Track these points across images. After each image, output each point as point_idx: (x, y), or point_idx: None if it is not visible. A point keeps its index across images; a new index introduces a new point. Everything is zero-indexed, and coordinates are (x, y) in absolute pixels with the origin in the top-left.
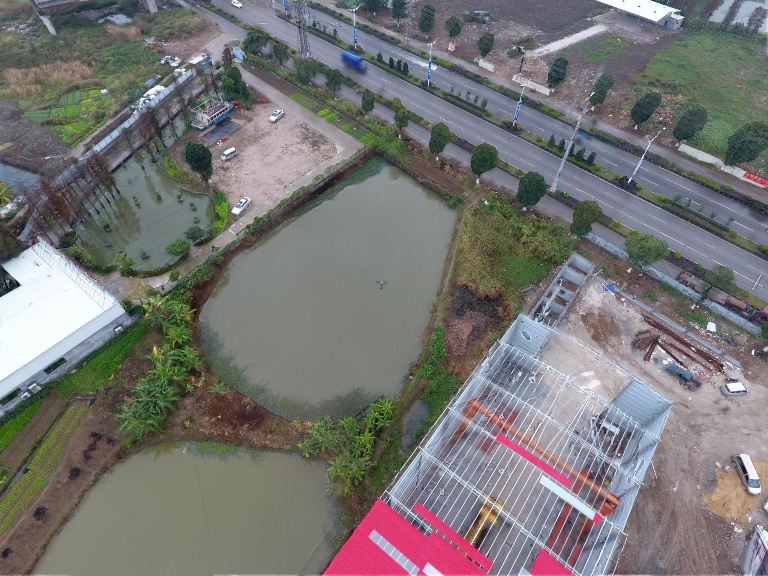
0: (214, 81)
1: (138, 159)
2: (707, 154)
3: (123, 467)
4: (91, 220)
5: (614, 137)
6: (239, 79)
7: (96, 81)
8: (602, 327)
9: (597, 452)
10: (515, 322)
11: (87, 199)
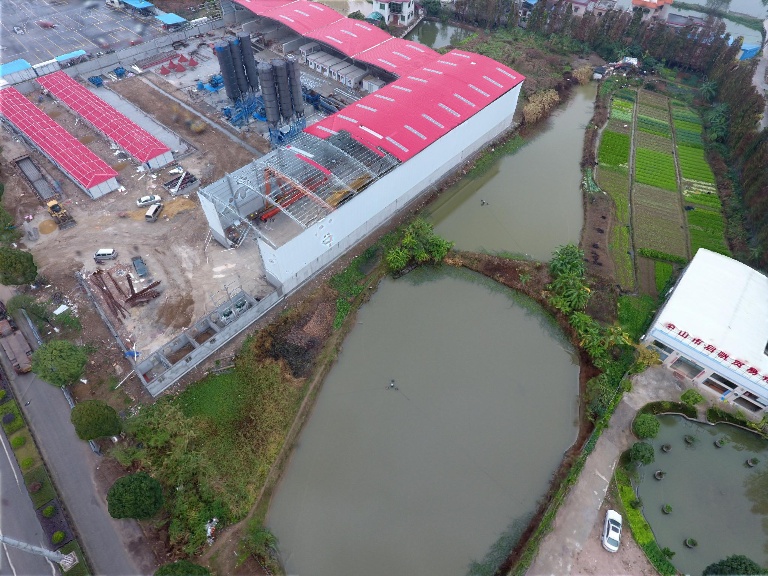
0: None
1: None
2: None
3: None
4: None
5: None
6: None
7: None
8: (176, 311)
9: (272, 165)
10: (283, 248)
11: None
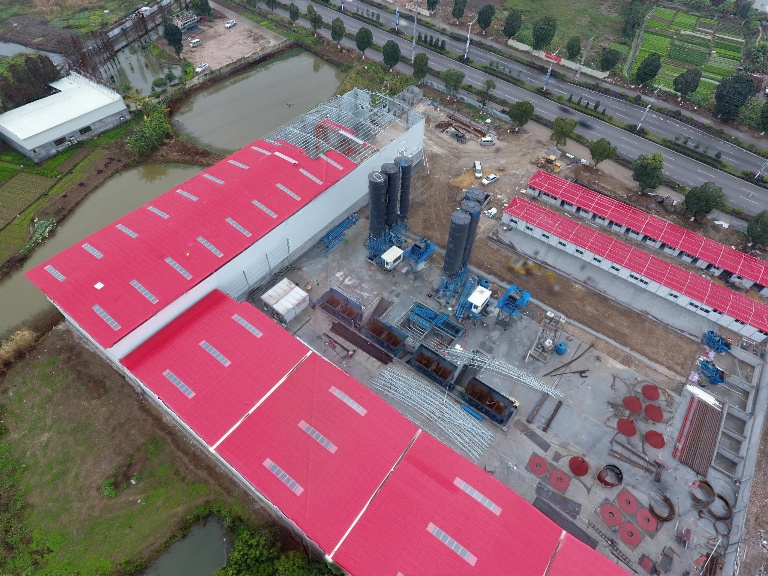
0: (186, 2)
1: (132, 52)
2: (524, 44)
3: (127, 175)
4: (101, 78)
5: (466, 37)
6: (204, 1)
7: (100, 5)
8: None
9: (373, 126)
10: (351, 93)
11: (99, 61)
